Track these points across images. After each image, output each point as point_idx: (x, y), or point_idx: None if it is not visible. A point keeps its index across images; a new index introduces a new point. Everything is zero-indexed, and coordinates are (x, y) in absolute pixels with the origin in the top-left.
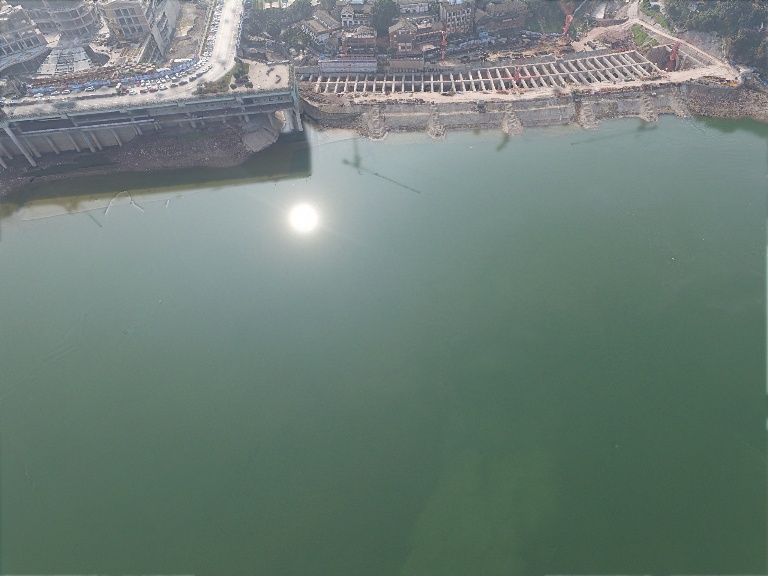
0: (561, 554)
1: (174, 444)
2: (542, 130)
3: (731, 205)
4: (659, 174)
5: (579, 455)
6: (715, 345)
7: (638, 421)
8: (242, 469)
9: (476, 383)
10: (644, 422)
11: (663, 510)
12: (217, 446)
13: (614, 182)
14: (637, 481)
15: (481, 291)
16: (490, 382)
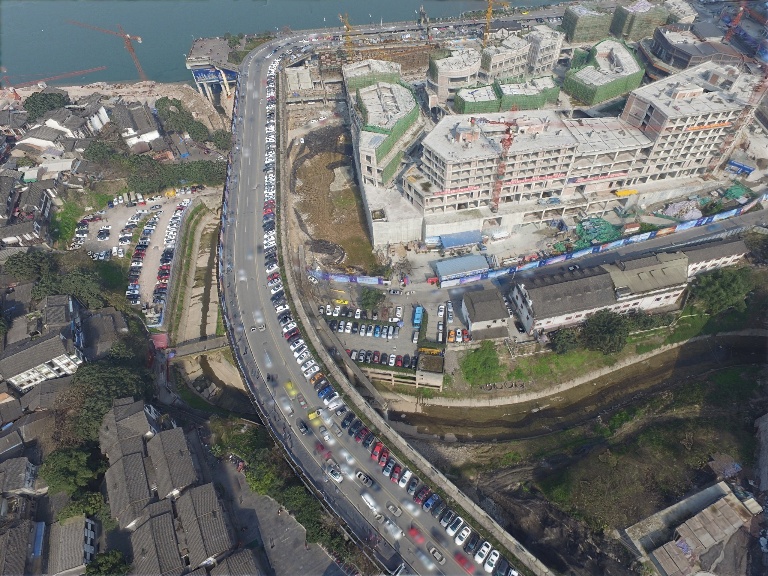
0: None
1: None
2: None
3: None
4: None
5: None
6: None
7: None
8: None
9: (167, 6)
10: None
11: None
12: None
13: (18, 59)
14: None
15: (144, 27)
16: None
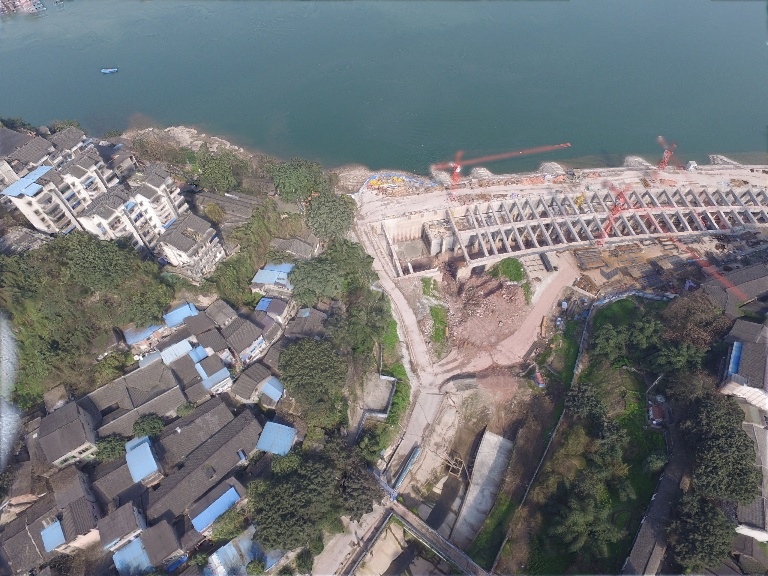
0: (581, 8)
1: (751, 27)
2: (603, 163)
3: (453, 94)
4: (497, 116)
5: None
6: (507, 38)
7: (547, 28)
8: (713, 21)
9: None
10: (545, 28)
11: (544, 14)
12: (730, 26)
13: (537, 111)
14: (551, 19)
15: None
16: (616, 34)
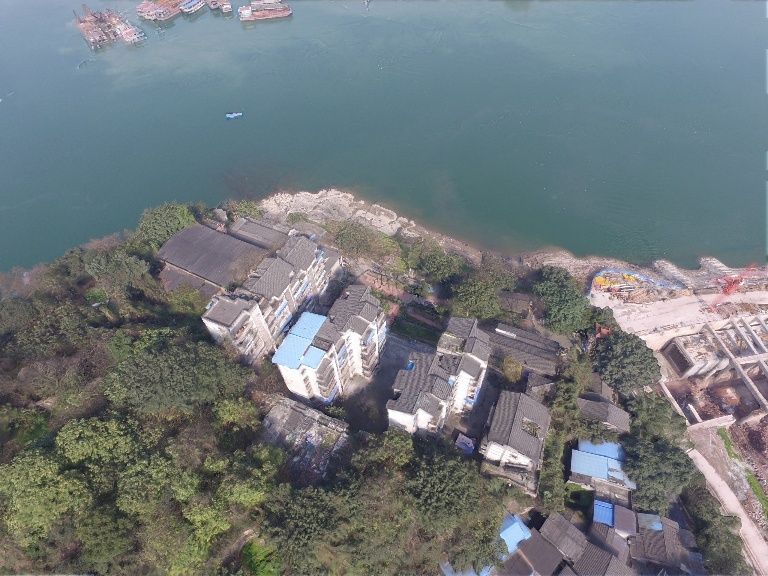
0: (741, 48)
1: None
2: None
3: (638, 156)
4: (701, 187)
5: (739, 66)
6: (674, 85)
7: (712, 73)
8: None
9: None
10: (709, 72)
11: None
12: None
13: (748, 181)
14: None
15: None
16: None
